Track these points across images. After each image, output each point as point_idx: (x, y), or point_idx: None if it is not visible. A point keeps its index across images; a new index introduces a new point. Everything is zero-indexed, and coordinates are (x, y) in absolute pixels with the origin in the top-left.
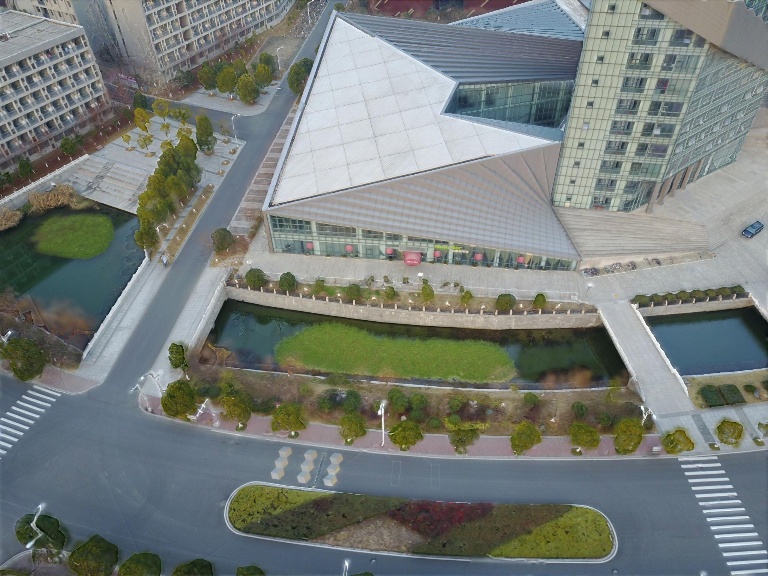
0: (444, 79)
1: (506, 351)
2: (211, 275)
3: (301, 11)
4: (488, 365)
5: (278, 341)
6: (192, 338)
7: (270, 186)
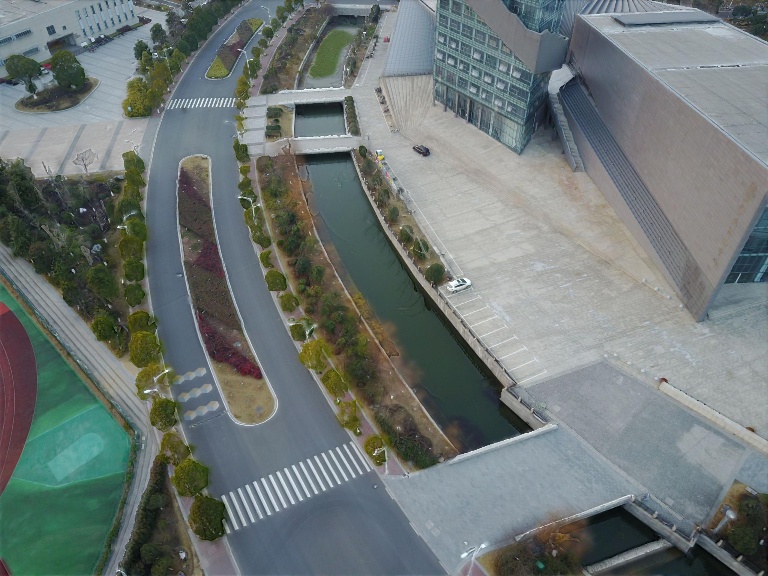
0: None
1: (329, 77)
2: None
3: (764, 3)
4: (319, 71)
5: (345, 29)
6: (339, 5)
7: None
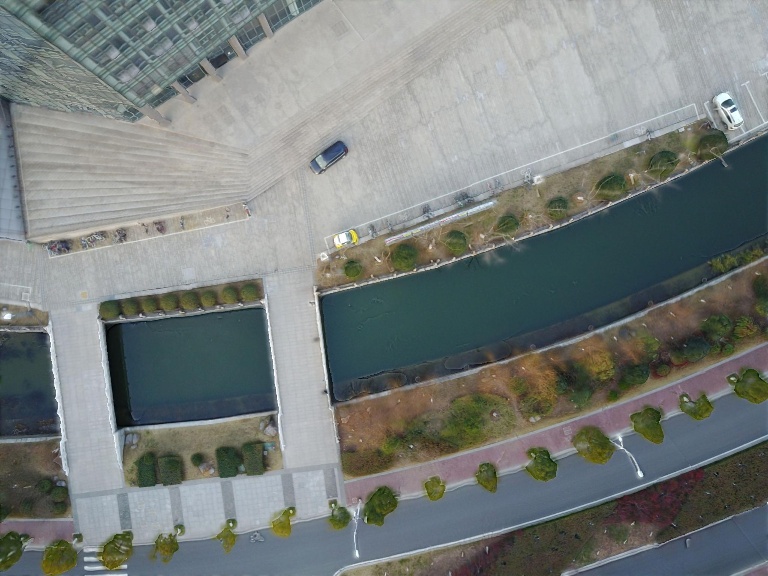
0: None
1: None
2: None
3: None
4: None
5: None
6: None
7: None
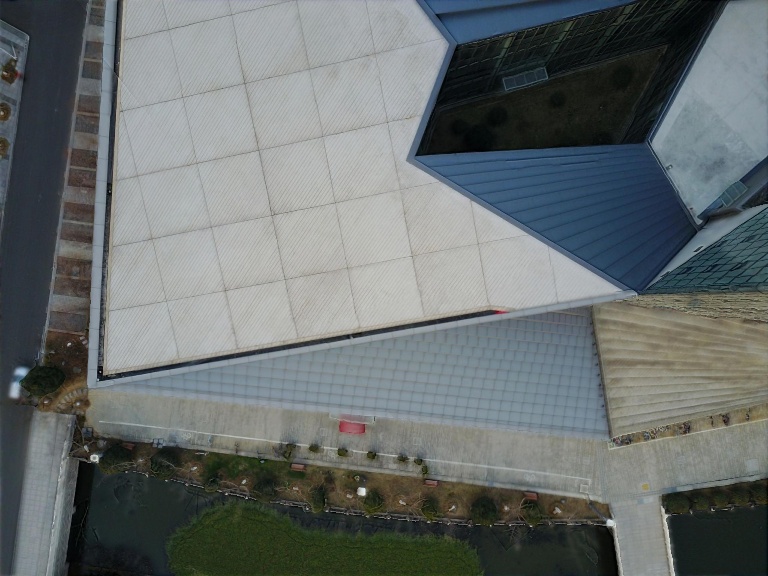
0: (423, 27)
1: (476, 555)
2: (45, 432)
3: None
4: None
5: (169, 535)
6: (46, 572)
7: (90, 329)
